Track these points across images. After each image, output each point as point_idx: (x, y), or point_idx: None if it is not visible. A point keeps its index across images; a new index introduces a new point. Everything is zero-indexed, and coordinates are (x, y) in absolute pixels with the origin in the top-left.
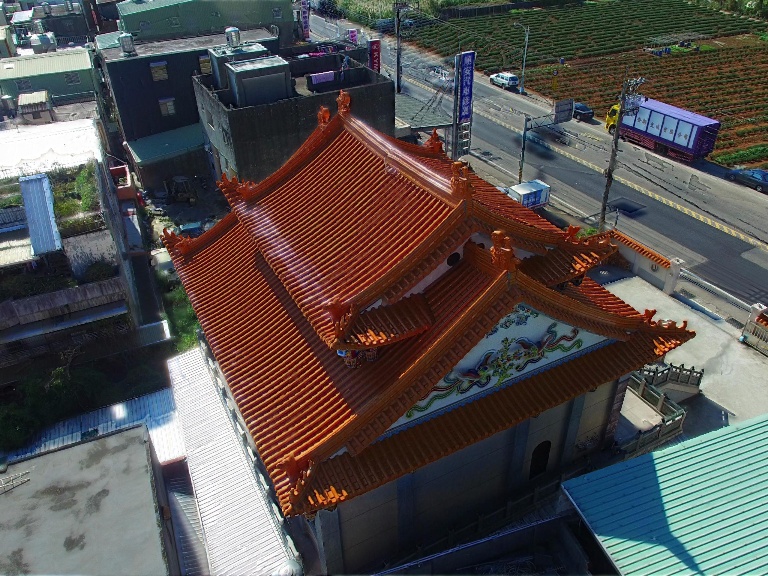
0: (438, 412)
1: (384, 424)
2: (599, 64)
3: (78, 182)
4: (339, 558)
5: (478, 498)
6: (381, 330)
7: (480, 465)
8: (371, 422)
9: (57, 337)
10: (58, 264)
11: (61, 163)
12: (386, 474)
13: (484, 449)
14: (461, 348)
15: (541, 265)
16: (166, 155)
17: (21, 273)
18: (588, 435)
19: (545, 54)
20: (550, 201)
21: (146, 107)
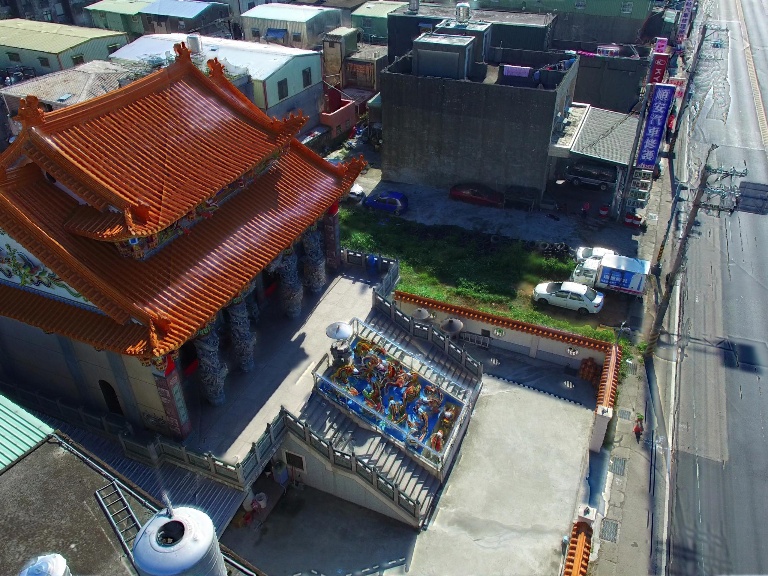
0: None
1: None
2: None
3: None
4: None
5: (64, 388)
6: None
7: None
8: None
9: None
10: None
11: (229, 70)
12: None
13: (46, 342)
14: None
15: (96, 217)
16: None
17: None
18: (156, 413)
19: None
20: None
21: None
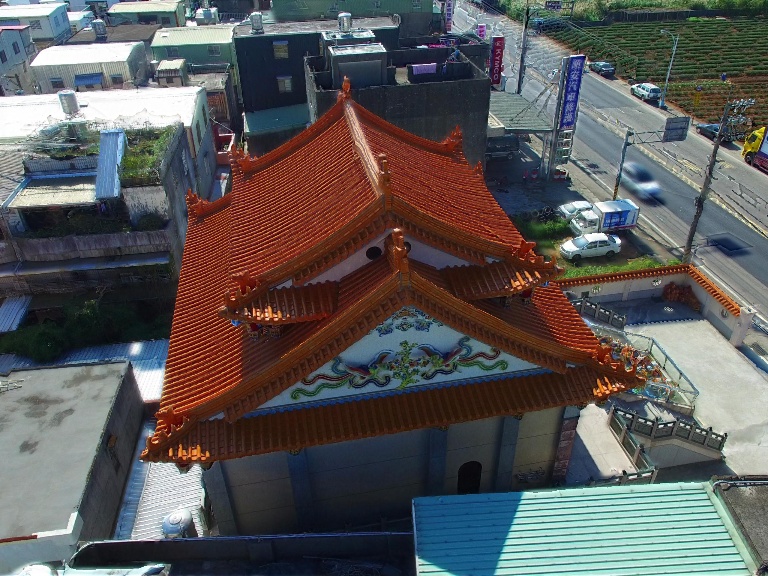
0: (329, 401)
1: (259, 399)
2: (767, 84)
3: (159, 141)
4: (230, 520)
5: (393, 501)
6: (280, 309)
7: (391, 467)
8: (250, 394)
9: (108, 274)
10: (122, 211)
11: (152, 122)
12: (253, 447)
13: (394, 452)
14: (343, 340)
15: (477, 275)
16: (272, 129)
17: (98, 214)
18: (532, 468)
19: (706, 68)
20: (641, 224)
21: (266, 82)
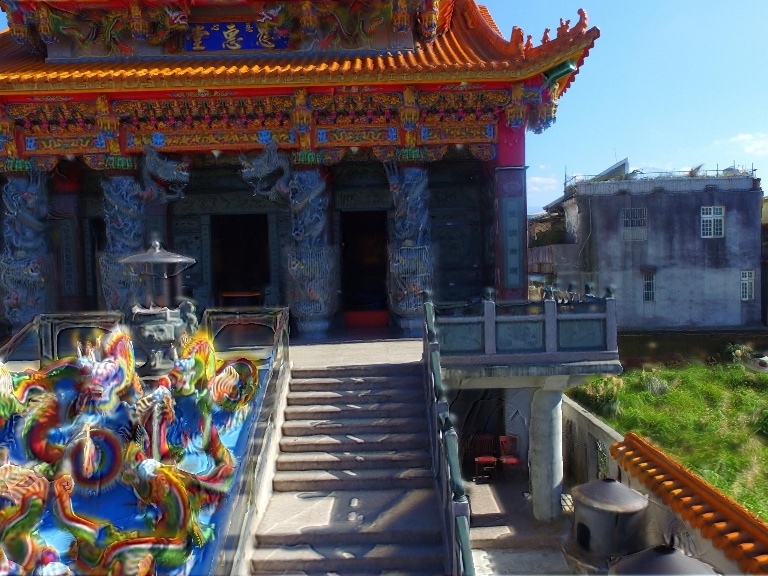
0: None
1: None
2: None
3: None
4: None
5: None
6: None
7: None
8: None
9: None
10: None
11: None
12: None
13: None
14: None
15: None
16: None
17: None
18: None
19: None
20: None
21: None
